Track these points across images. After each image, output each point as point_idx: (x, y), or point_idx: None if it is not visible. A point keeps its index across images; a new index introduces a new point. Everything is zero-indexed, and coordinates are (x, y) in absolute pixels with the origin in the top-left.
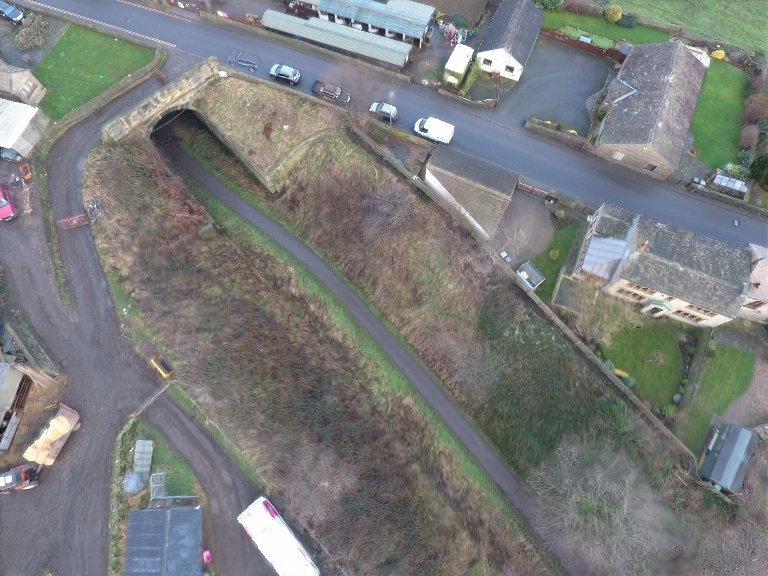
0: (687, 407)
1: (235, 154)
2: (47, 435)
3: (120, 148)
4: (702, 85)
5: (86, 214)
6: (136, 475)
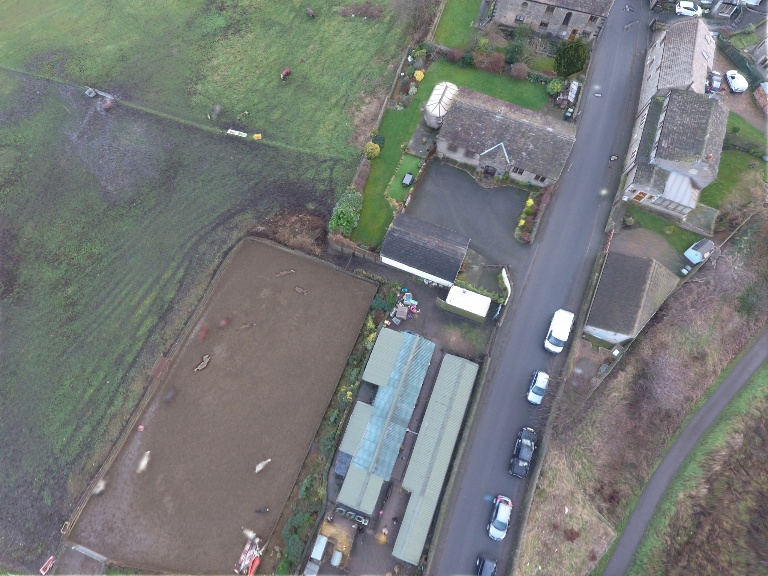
0: None
1: None
2: None
3: None
4: None
5: None
6: None
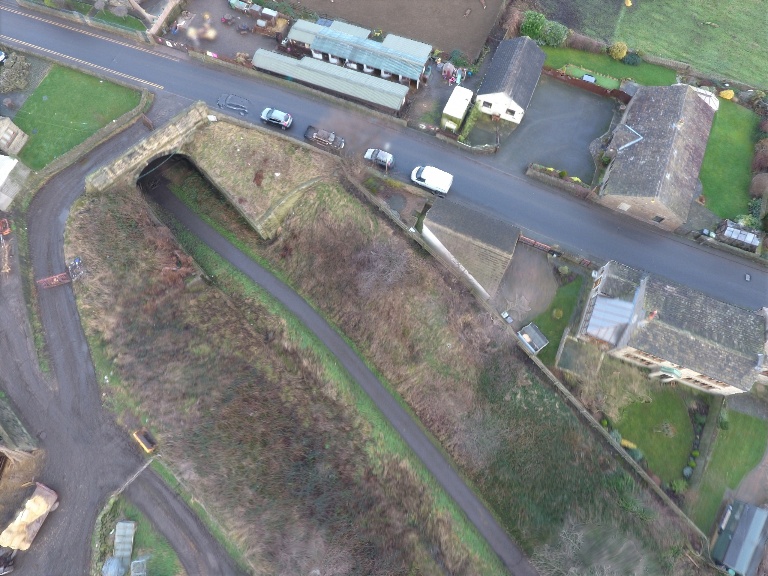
0: (698, 483)
1: (226, 197)
2: (22, 518)
3: (104, 198)
4: (711, 130)
5: (67, 272)
6: (116, 560)
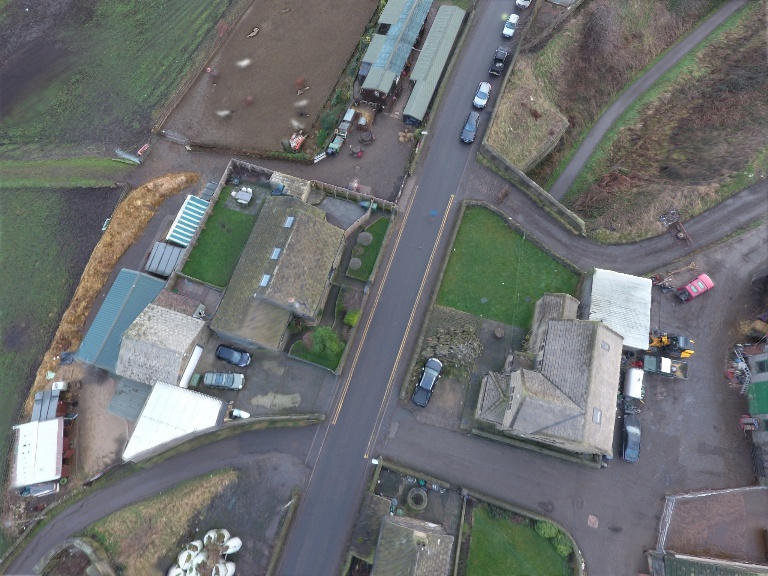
0: None
1: None
2: None
3: None
4: None
5: None
6: None
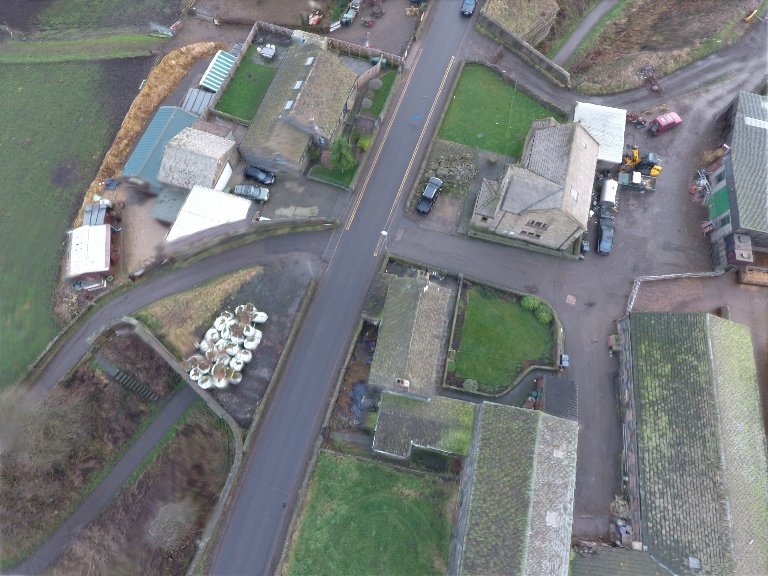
0: None
1: None
2: None
3: None
4: None
5: None
6: None
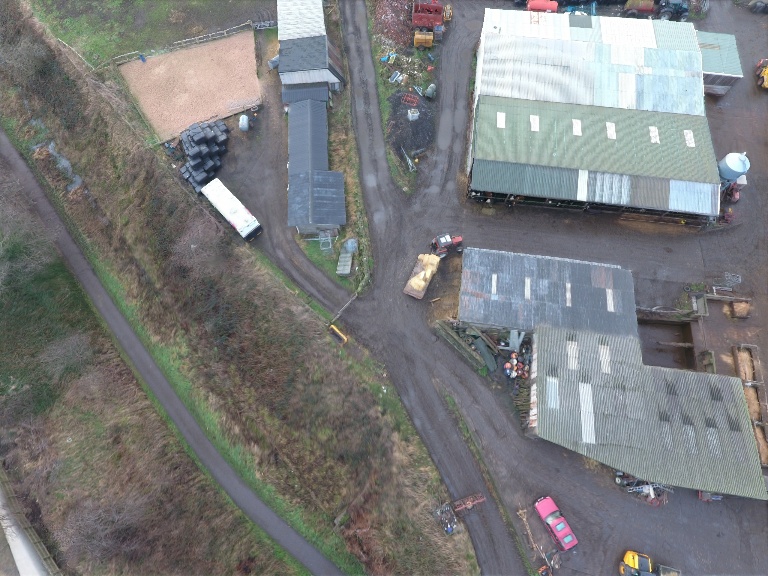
0: None
1: None
2: (423, 273)
3: None
4: None
5: None
6: (349, 250)
